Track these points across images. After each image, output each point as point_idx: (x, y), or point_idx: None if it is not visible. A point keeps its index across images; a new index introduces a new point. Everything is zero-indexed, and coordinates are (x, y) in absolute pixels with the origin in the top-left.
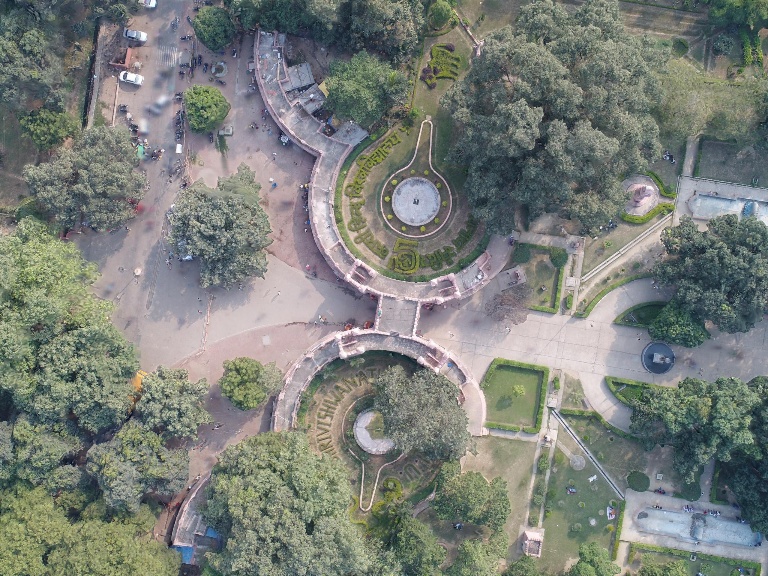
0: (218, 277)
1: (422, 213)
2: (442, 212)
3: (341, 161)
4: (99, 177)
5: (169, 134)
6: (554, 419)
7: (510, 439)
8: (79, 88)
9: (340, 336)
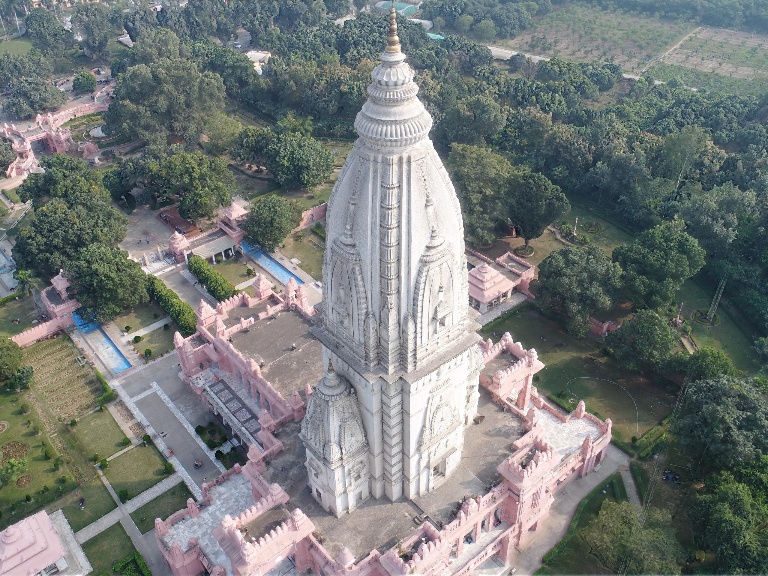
0: (8, 104)
1: (100, 135)
2: (107, 138)
3: (98, 107)
4: (22, 61)
5: (68, 90)
6: (28, 205)
7: (2, 201)
8: (66, 75)
9: (8, 127)
